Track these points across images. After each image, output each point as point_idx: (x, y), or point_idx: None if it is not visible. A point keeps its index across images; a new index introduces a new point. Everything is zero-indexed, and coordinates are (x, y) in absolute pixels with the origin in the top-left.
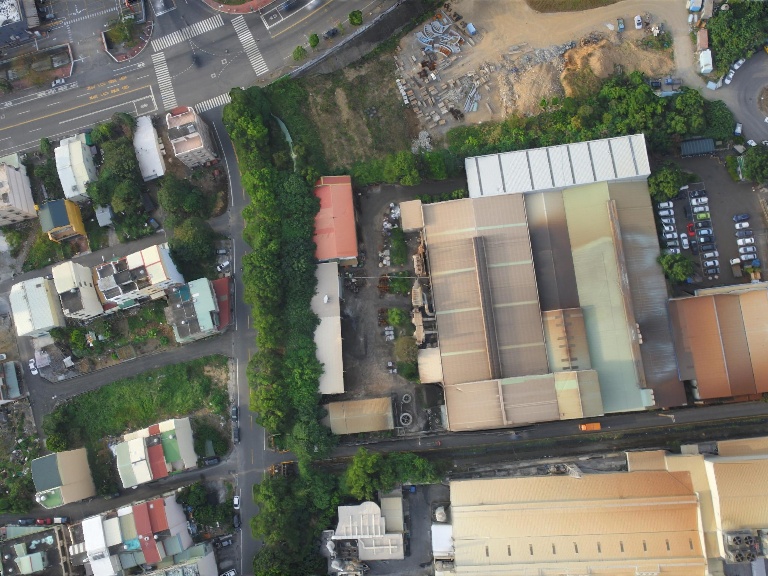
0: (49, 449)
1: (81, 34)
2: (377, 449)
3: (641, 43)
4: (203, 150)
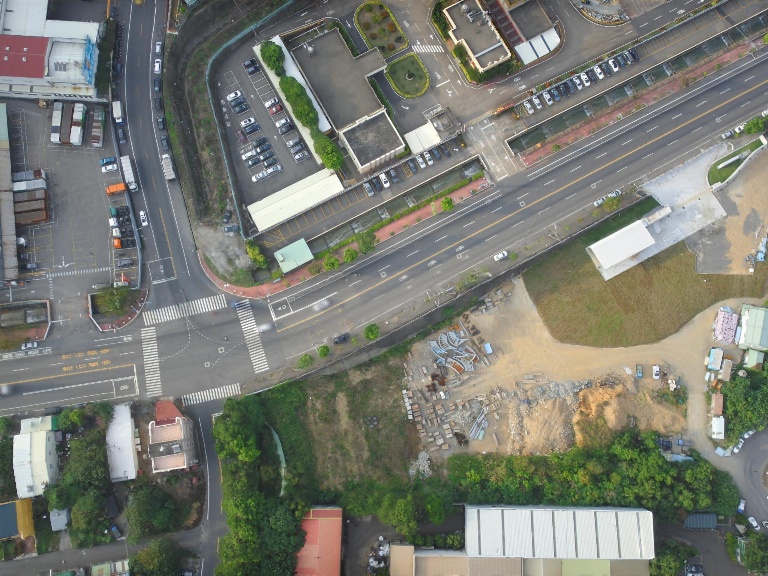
0: None
1: (64, 291)
2: None
3: (656, 394)
4: None
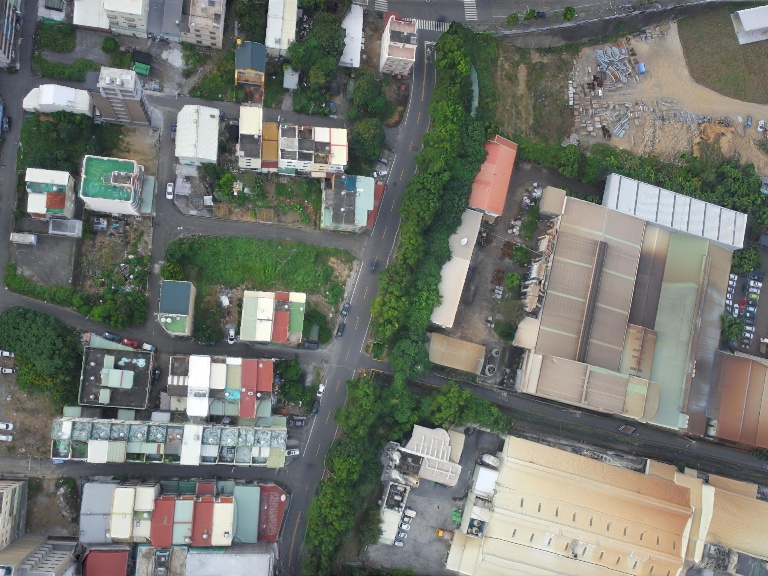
0: (164, 276)
1: None
2: None
3: (757, 143)
4: (410, 63)
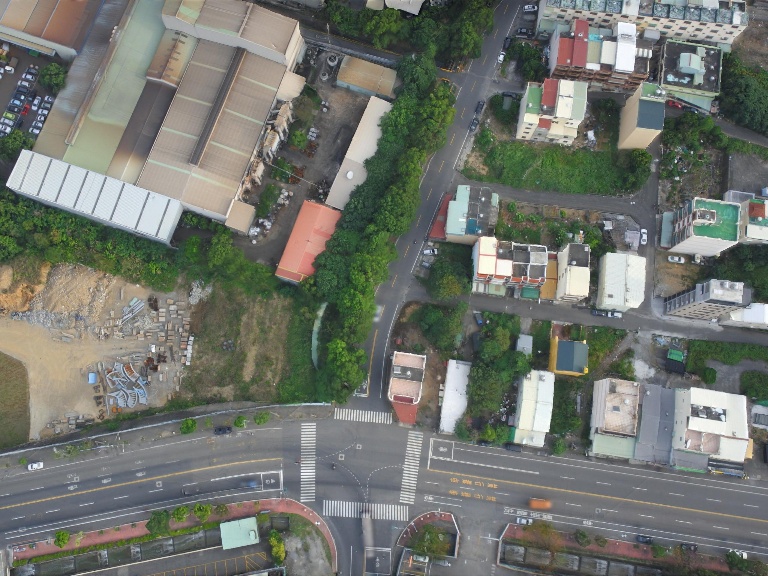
0: (650, 155)
1: (480, 569)
2: (366, 45)
3: None
4: None
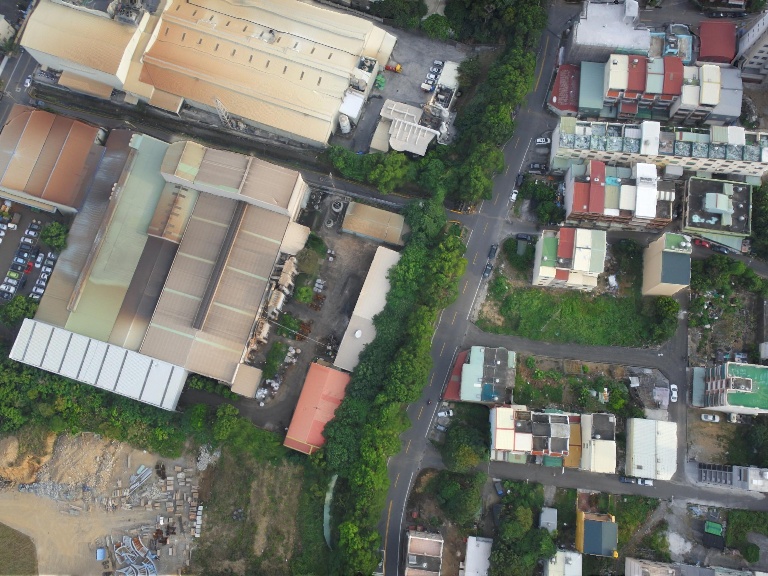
0: (677, 304)
1: None
2: (372, 190)
3: None
4: None
